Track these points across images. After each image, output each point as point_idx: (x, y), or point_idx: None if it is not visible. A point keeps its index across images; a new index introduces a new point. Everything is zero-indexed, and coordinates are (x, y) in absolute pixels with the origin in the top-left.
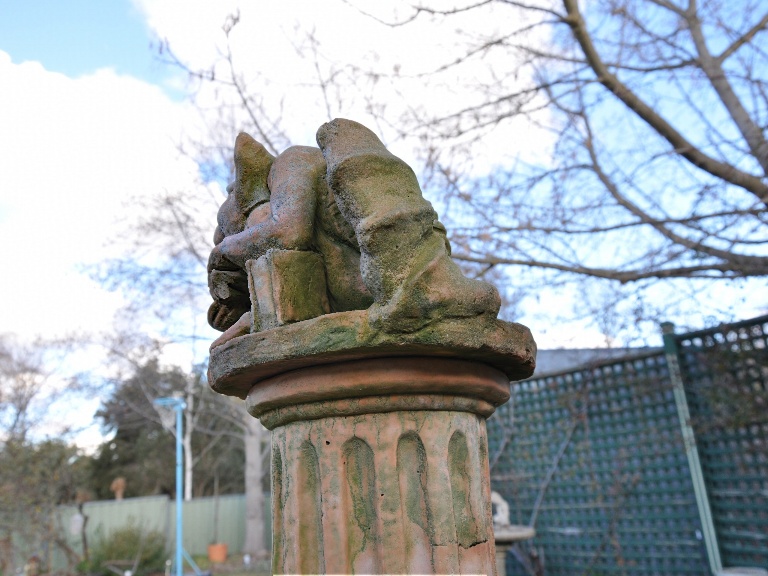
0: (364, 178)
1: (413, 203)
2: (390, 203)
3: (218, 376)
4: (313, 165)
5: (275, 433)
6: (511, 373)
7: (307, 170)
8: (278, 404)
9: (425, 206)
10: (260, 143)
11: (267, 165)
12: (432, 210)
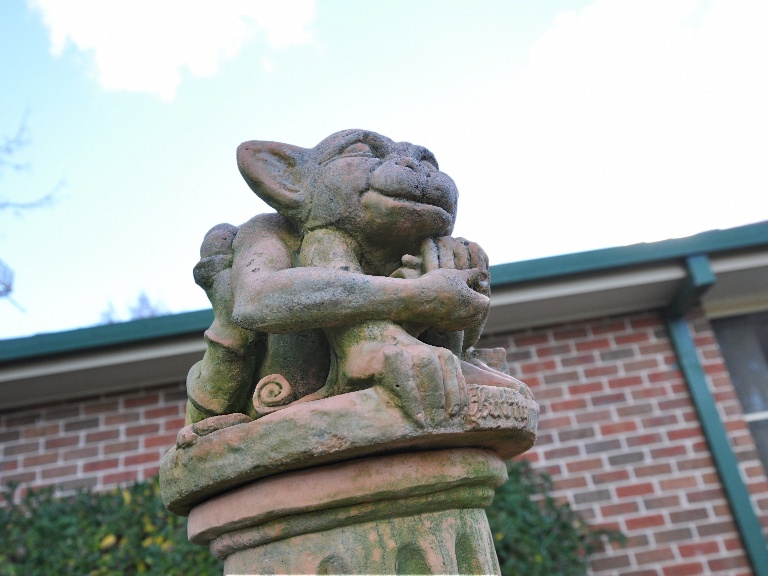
0: None
1: None
2: None
3: None
4: None
5: None
6: None
7: None
8: None
9: None
10: None
11: None
12: None
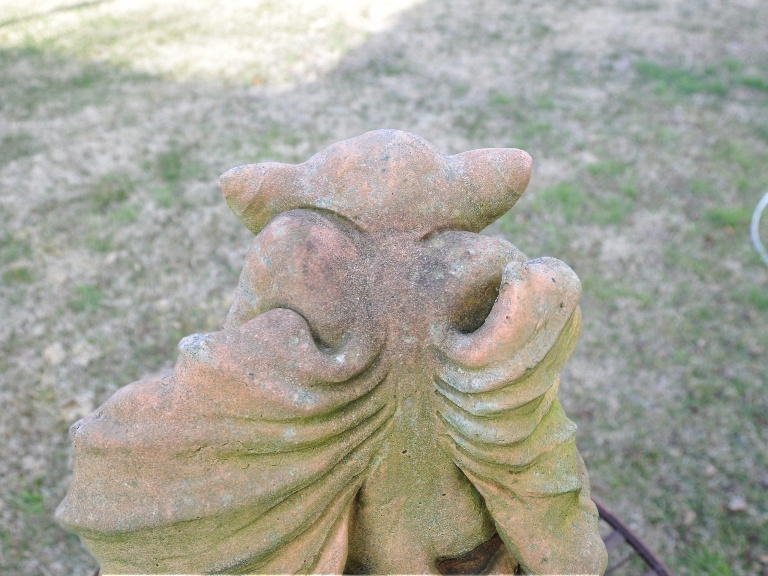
0: (84, 537)
1: (165, 572)
2: (115, 573)
3: None
4: (259, 298)
5: None
6: None
7: (249, 306)
8: None
9: (199, 571)
10: (254, 188)
11: (266, 224)
12: (235, 563)
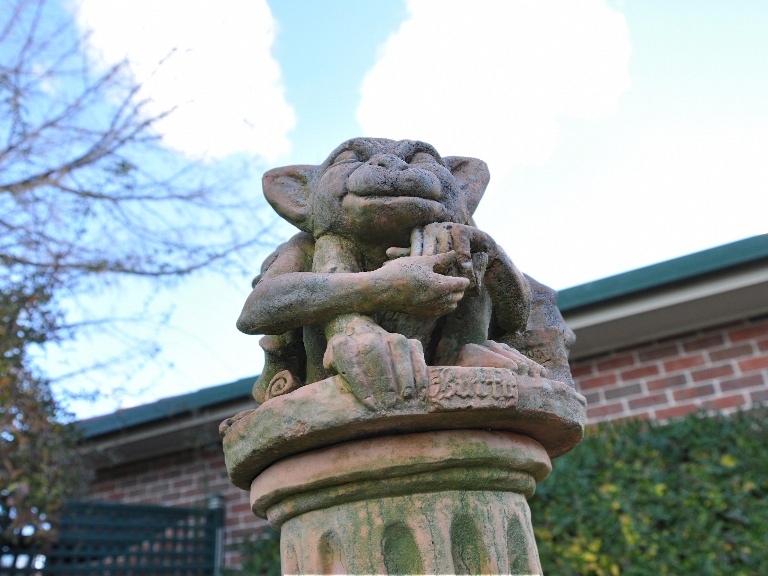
0: None
1: None
2: None
3: (557, 412)
4: None
5: (509, 498)
6: None
7: None
8: (537, 470)
9: None
10: None
11: None
12: None
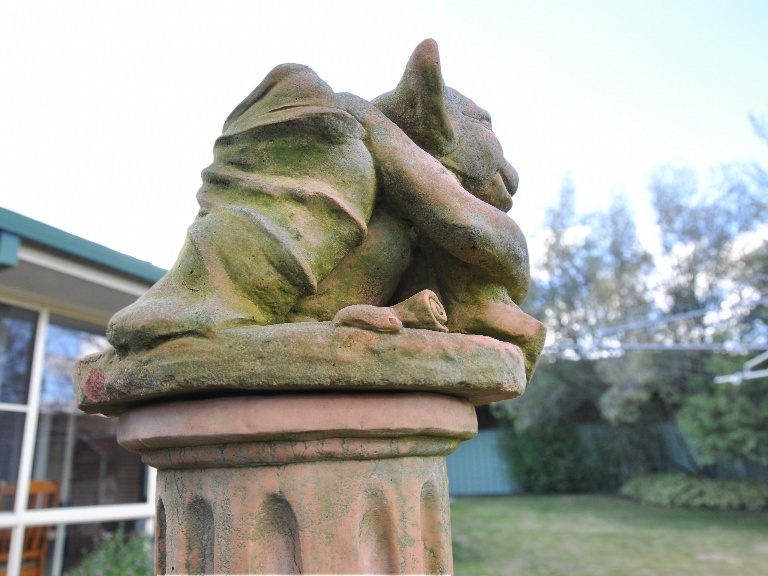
0: None
1: None
2: None
3: None
4: None
5: None
6: (116, 408)
7: None
8: None
9: None
10: None
11: None
12: None
